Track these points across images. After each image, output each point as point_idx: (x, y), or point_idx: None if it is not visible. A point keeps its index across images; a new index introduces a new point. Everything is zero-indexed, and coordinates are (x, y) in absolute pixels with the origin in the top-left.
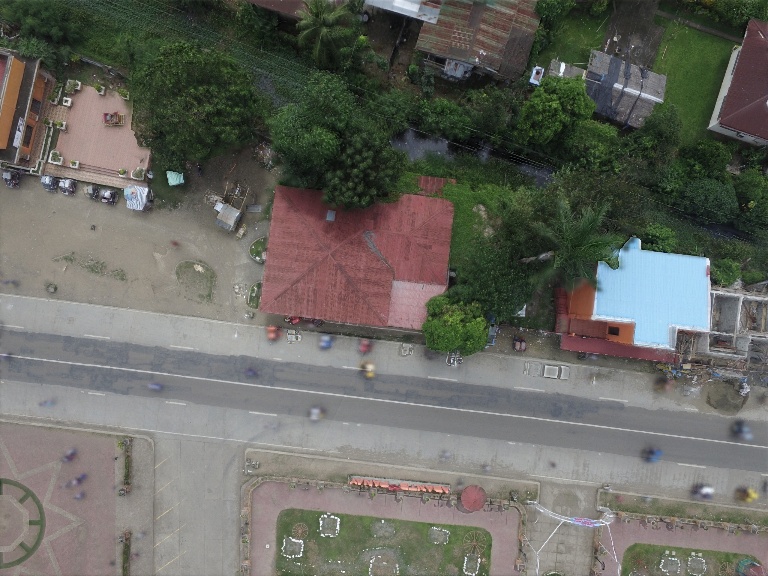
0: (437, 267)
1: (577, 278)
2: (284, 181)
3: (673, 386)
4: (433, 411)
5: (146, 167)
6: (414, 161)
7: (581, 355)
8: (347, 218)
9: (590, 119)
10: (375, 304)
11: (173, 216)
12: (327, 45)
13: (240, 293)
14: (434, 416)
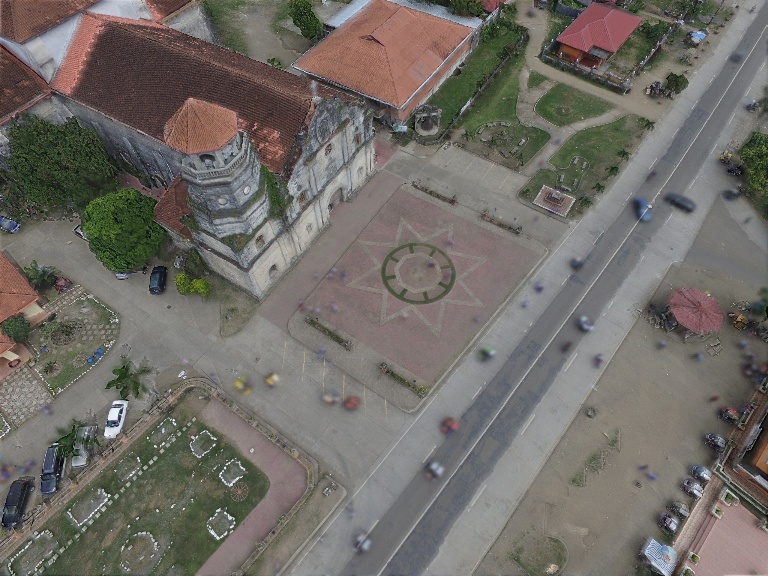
0: None
1: None
2: None
3: None
4: None
5: None
6: None
7: None
8: None
9: None
10: None
11: None
12: None
13: None
14: None
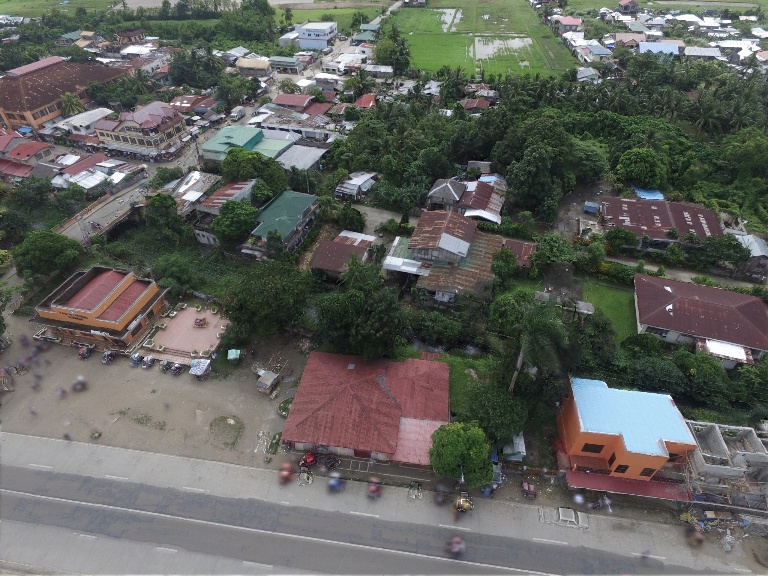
0: (439, 406)
1: (564, 420)
2: None
3: (708, 541)
4: (447, 565)
5: (213, 350)
6: None
7: (595, 504)
8: (364, 368)
9: None
10: (385, 432)
11: (222, 384)
12: None
13: (263, 439)
14: (449, 572)
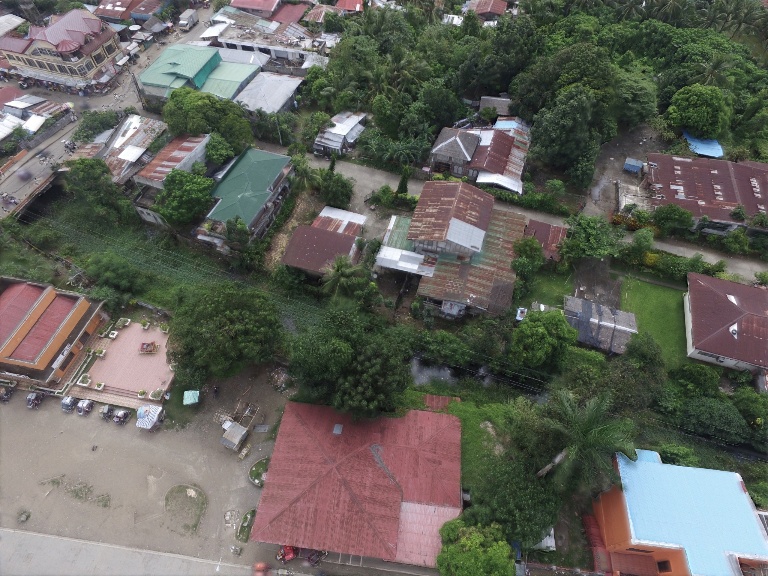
0: (449, 486)
1: (604, 500)
2: (295, 398)
3: None
4: None
5: (166, 388)
6: (419, 385)
7: None
8: (354, 431)
9: (576, 347)
10: (382, 529)
11: (179, 436)
12: (343, 290)
13: (231, 522)
14: None
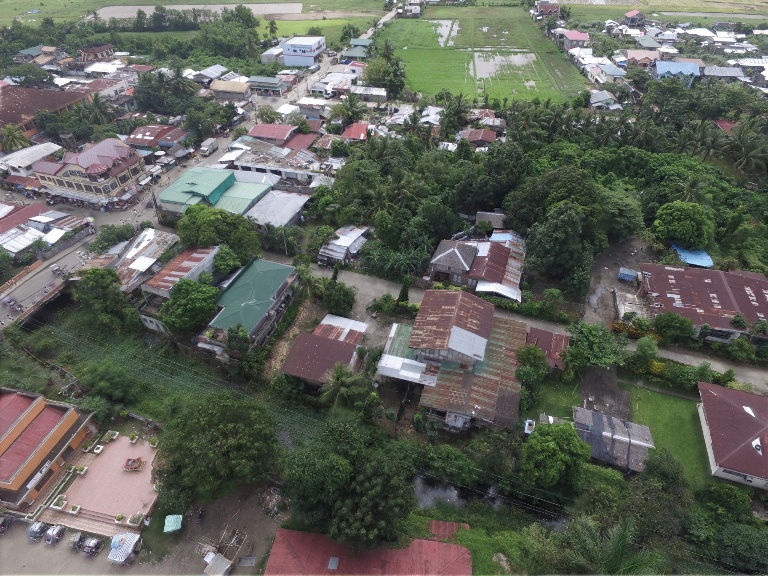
0: None
1: None
2: (287, 524)
3: None
4: None
5: (147, 512)
6: (423, 508)
7: None
8: (351, 566)
9: (591, 464)
10: None
11: (154, 571)
12: (343, 401)
13: None
14: None
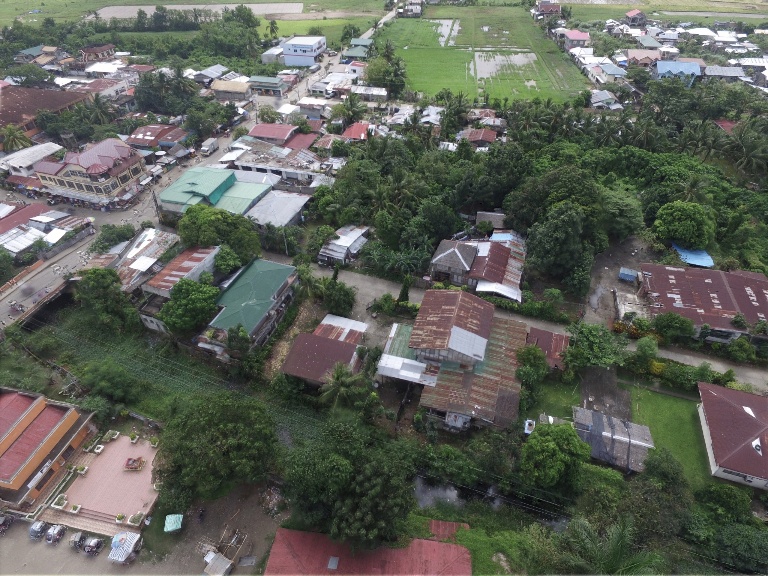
0: None
1: None
2: (287, 524)
3: None
4: None
5: (147, 512)
6: (423, 508)
7: None
8: (351, 566)
9: (591, 464)
10: None
11: (155, 571)
12: (343, 401)
13: None
14: None
